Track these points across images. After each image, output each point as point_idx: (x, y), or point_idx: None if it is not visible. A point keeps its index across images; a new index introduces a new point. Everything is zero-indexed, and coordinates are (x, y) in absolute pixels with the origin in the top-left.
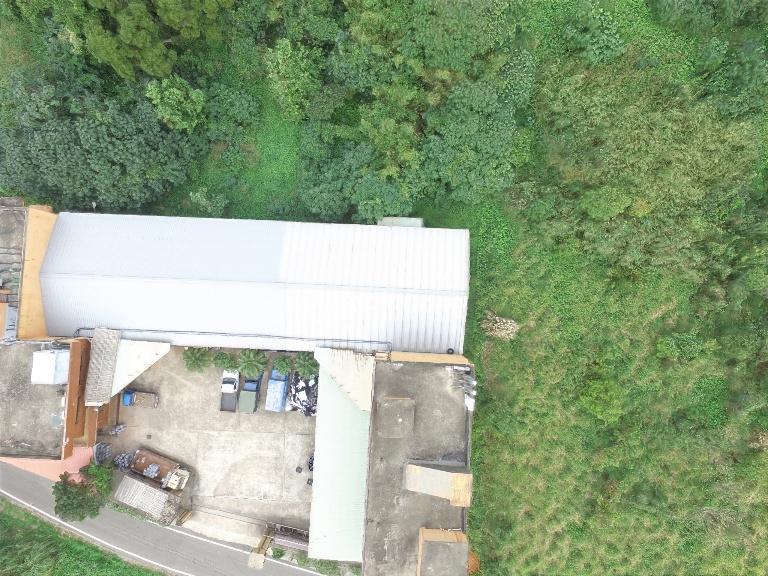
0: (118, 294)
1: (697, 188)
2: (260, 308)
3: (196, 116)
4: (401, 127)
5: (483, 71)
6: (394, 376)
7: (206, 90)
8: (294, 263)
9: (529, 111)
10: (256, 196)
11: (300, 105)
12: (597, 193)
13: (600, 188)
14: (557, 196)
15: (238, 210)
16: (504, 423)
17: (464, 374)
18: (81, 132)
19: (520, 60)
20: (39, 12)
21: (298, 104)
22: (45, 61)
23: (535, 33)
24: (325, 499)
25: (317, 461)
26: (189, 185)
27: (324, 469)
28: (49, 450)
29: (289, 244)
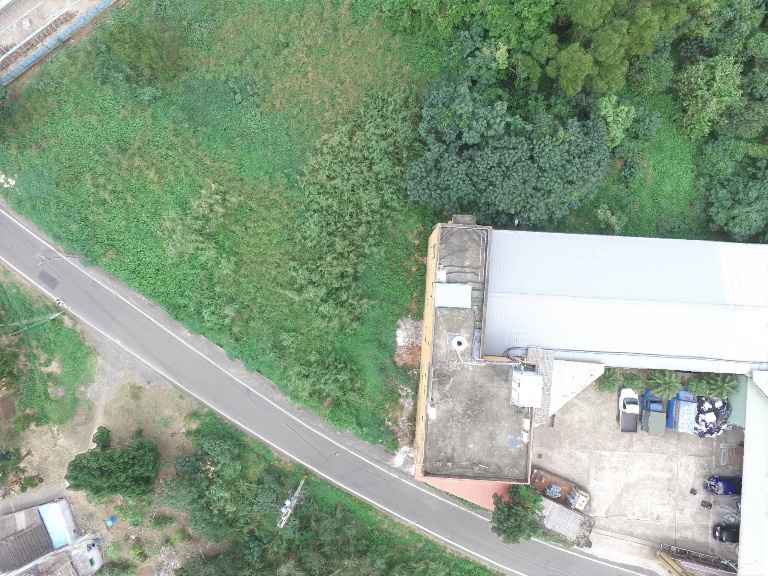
0: (559, 314)
1: None
2: (702, 330)
3: None
4: None
5: None
6: None
7: None
8: (737, 285)
9: None
10: (646, 213)
11: (712, 122)
12: None
13: None
14: None
15: (626, 227)
16: None
17: None
18: (538, 150)
19: None
20: (453, 25)
21: (710, 121)
22: (425, 73)
23: None
24: (755, 524)
25: (746, 485)
26: None
27: (754, 493)
28: (506, 472)
29: (726, 265)
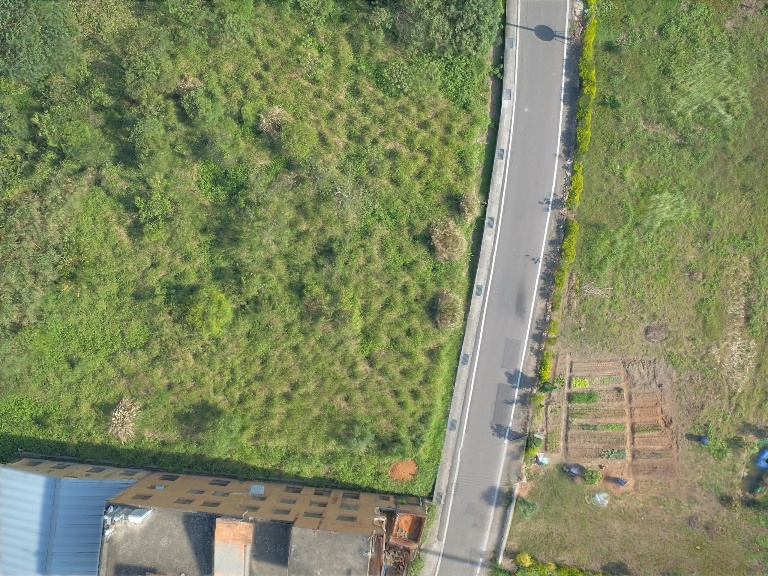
0: None
1: None
2: None
3: None
4: None
5: None
6: None
7: None
8: None
9: None
10: None
11: None
12: None
13: None
14: None
15: None
16: (223, 433)
17: None
18: None
19: None
20: None
21: None
22: None
23: None
24: None
25: None
26: None
27: None
28: None
29: None
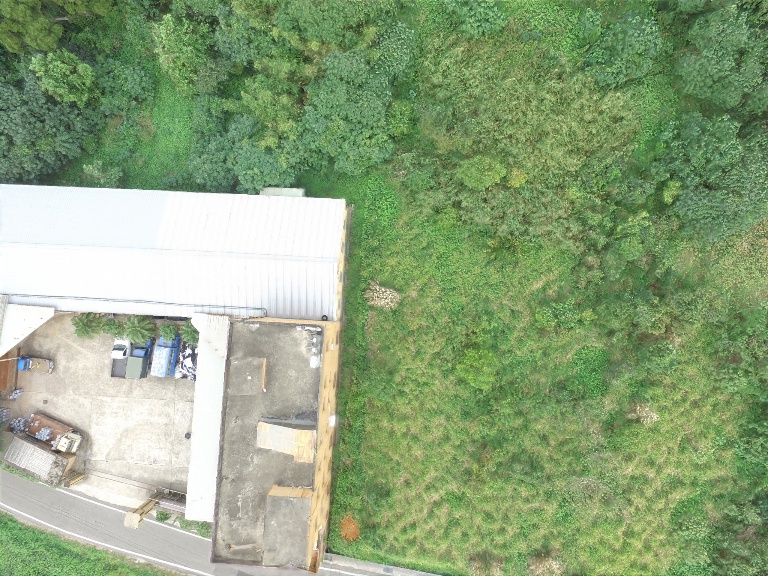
0: (4, 260)
1: (577, 159)
2: (139, 274)
3: (87, 90)
4: (280, 99)
5: (356, 43)
6: (251, 337)
7: (100, 66)
8: (172, 230)
9: (413, 85)
10: (152, 169)
11: (189, 80)
12: (469, 162)
13: (473, 158)
14: (435, 167)
15: (135, 183)
16: (377, 389)
17: (315, 334)
18: None
19: (396, 33)
20: None
21: (187, 79)
22: None
23: (420, 8)
24: (202, 462)
25: (195, 425)
26: (88, 159)
27: (202, 432)
28: None
29: (169, 212)
